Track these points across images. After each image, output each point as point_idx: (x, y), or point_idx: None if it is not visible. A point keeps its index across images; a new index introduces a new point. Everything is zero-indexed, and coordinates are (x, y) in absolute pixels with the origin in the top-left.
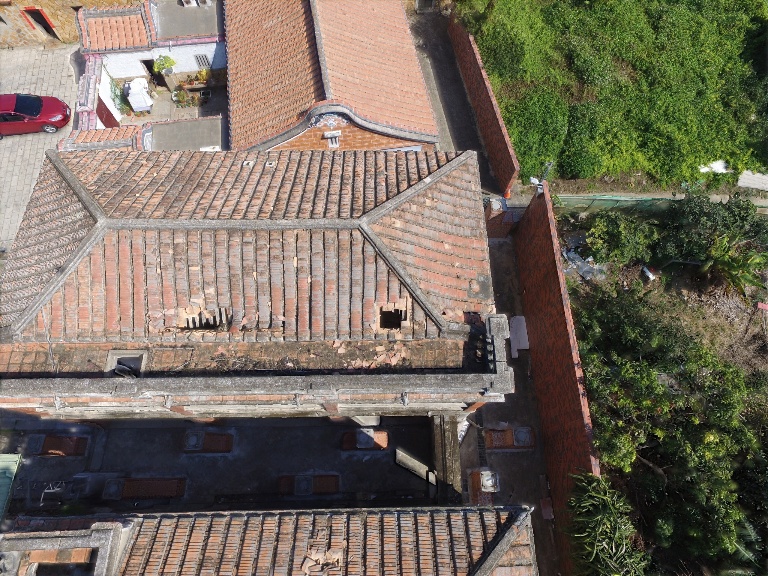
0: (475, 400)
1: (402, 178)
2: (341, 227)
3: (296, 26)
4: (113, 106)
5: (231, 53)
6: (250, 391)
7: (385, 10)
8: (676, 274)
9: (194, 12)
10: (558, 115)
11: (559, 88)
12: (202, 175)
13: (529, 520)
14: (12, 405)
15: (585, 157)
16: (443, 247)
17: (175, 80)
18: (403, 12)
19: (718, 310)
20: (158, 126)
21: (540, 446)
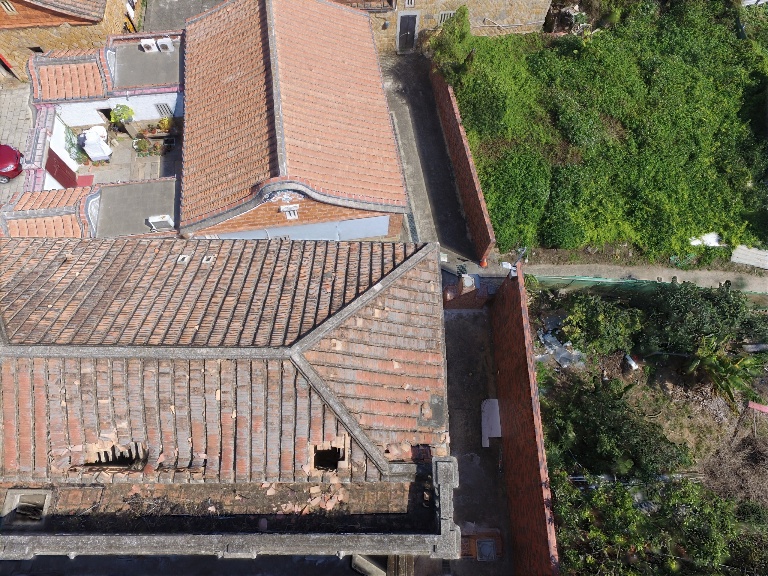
0: (420, 552)
1: (351, 282)
2: (270, 358)
3: (256, 84)
4: (68, 157)
5: (188, 109)
6: None
7: (357, 62)
8: (661, 364)
9: (155, 58)
10: (539, 179)
11: (542, 147)
12: (129, 275)
13: None
14: None
15: (567, 227)
16: (392, 367)
17: (136, 128)
18: (377, 63)
19: (705, 407)
20: (107, 188)
21: (509, 551)
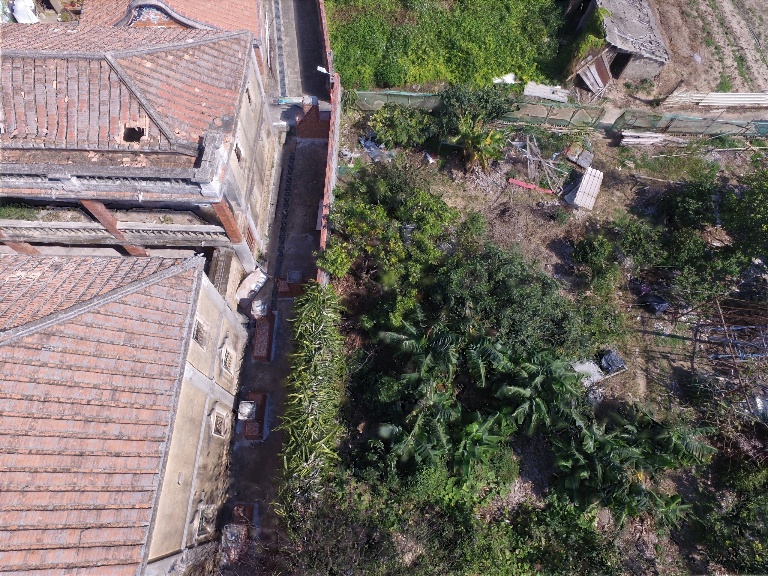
0: (197, 200)
1: None
2: (91, 57)
3: None
4: None
5: None
6: (12, 182)
7: None
8: (450, 158)
9: None
10: (377, 33)
11: (386, 14)
12: None
13: (202, 267)
14: None
15: (393, 66)
16: (193, 90)
17: (60, 2)
18: None
19: (478, 185)
20: None
21: None
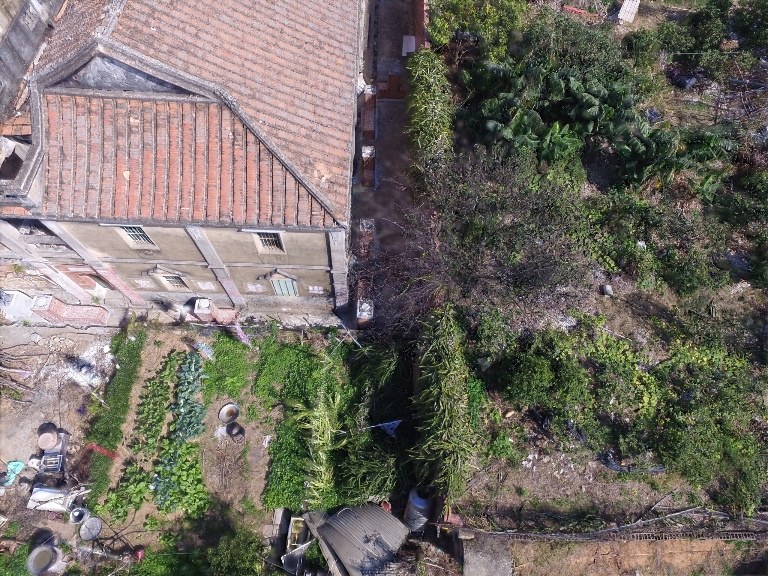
0: None
1: None
2: None
3: None
4: None
5: None
6: None
7: None
8: None
9: None
10: None
11: None
12: None
13: None
14: None
15: None
16: None
17: None
18: None
19: None
20: None
21: None
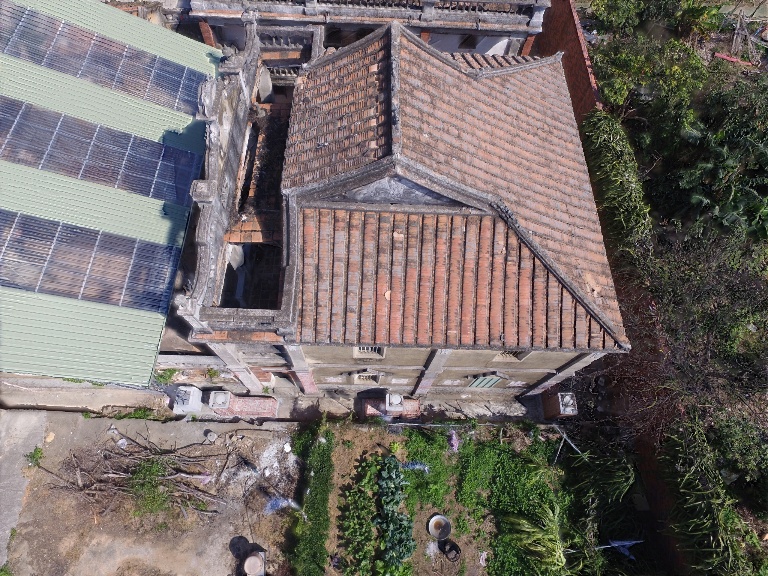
0: (523, 29)
1: None
2: None
3: None
4: None
5: None
6: (381, 10)
7: None
8: None
9: None
10: None
11: None
12: None
13: None
14: (227, 15)
15: None
16: None
17: None
18: None
19: None
20: None
21: None
